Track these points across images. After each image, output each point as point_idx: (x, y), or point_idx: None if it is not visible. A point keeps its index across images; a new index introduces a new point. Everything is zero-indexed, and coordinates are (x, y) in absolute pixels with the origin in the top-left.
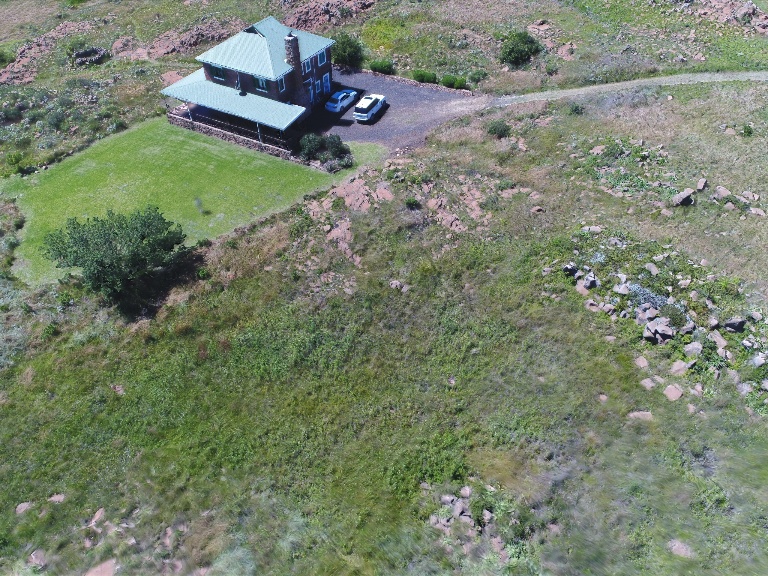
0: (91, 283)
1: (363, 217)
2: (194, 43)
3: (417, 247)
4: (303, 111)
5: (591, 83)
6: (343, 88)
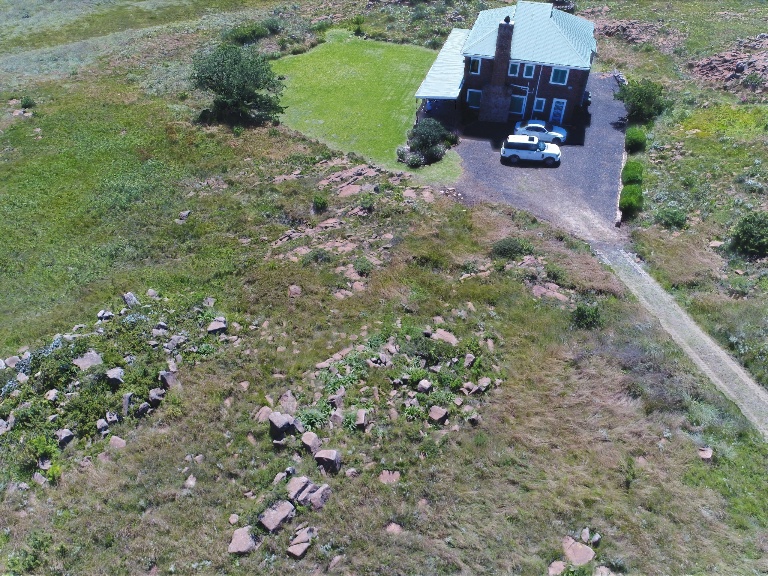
0: (191, 77)
1: (299, 181)
2: (611, 33)
3: (239, 217)
4: (453, 97)
5: (726, 343)
6: (577, 130)
